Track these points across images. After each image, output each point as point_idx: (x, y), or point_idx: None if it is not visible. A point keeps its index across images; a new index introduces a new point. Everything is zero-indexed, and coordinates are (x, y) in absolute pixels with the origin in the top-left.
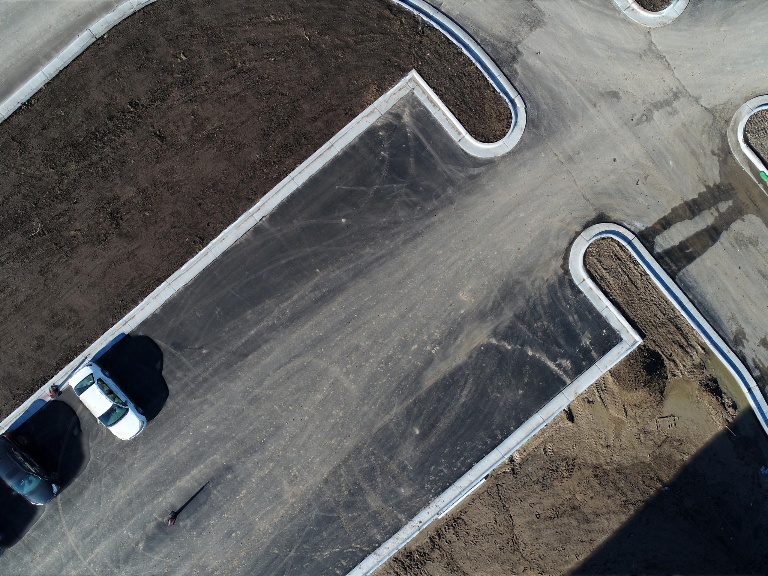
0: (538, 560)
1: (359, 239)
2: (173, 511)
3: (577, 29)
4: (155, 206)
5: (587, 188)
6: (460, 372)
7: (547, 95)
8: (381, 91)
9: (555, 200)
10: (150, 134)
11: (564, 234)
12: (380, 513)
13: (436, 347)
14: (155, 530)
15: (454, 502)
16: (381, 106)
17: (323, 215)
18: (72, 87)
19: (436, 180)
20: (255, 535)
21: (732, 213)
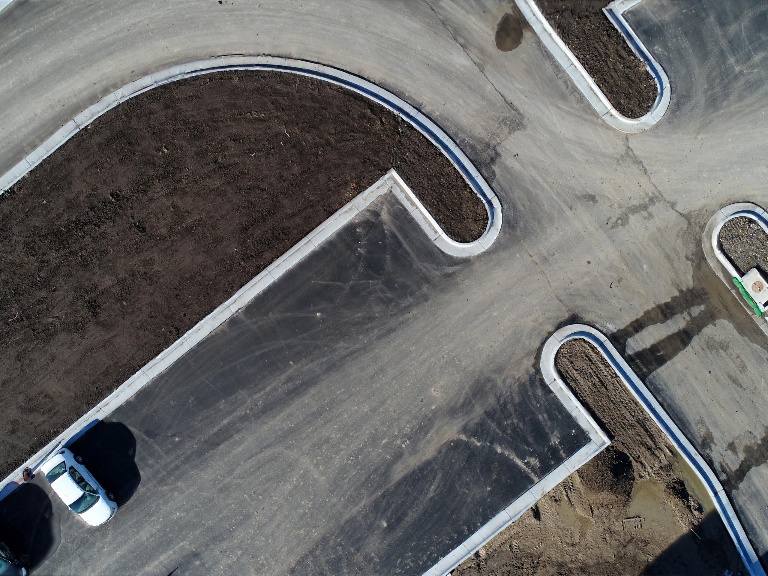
0: None
1: (333, 333)
2: None
3: (555, 133)
4: (132, 296)
5: (561, 289)
6: (429, 467)
7: (524, 197)
8: (359, 189)
9: (529, 300)
10: (130, 225)
11: (536, 334)
12: None
13: (406, 441)
14: None
15: None
16: (359, 203)
17: (298, 309)
18: (54, 176)
19: (411, 277)
20: None
21: (704, 318)
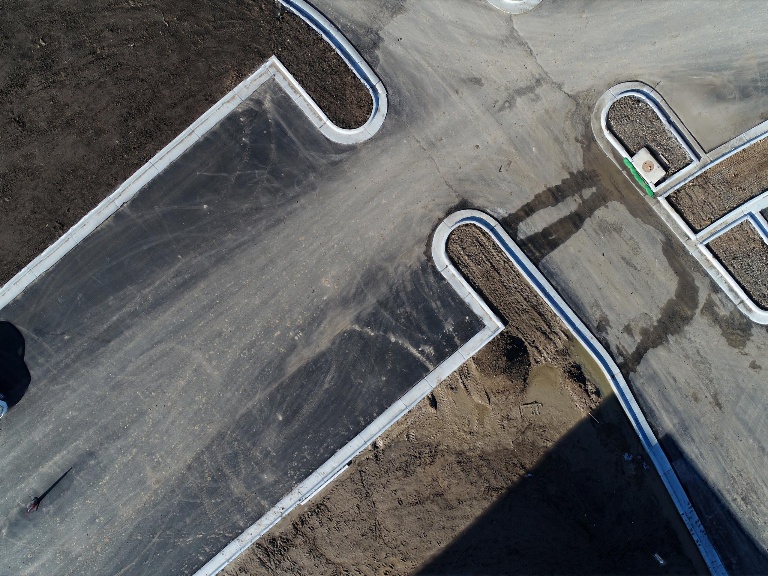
0: (400, 546)
1: (221, 225)
2: (36, 497)
3: (438, 15)
4: (15, 192)
5: (450, 175)
6: (323, 358)
7: (409, 81)
8: (241, 77)
9: (418, 187)
10: (10, 120)
11: (427, 221)
12: (243, 499)
13: (299, 333)
14: (18, 516)
15: (317, 488)
16: (242, 92)
17: (184, 201)
18: None
19: (298, 166)
20: (118, 521)
21: (596, 200)
